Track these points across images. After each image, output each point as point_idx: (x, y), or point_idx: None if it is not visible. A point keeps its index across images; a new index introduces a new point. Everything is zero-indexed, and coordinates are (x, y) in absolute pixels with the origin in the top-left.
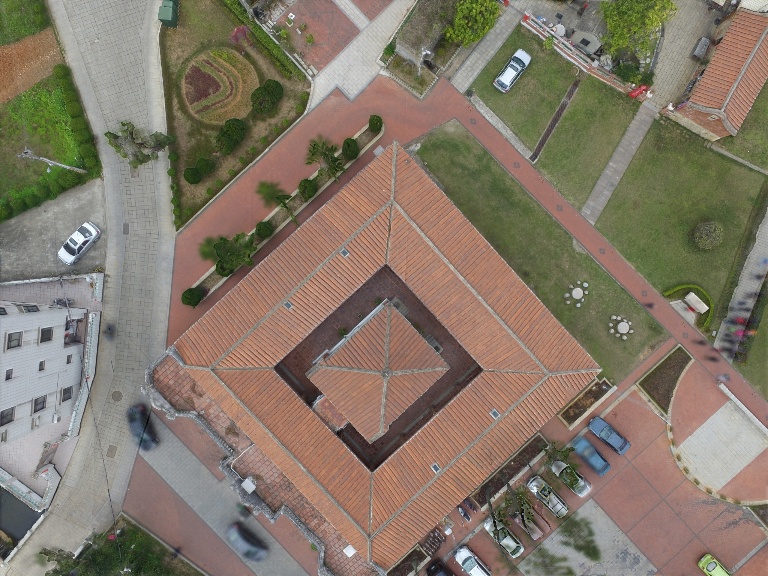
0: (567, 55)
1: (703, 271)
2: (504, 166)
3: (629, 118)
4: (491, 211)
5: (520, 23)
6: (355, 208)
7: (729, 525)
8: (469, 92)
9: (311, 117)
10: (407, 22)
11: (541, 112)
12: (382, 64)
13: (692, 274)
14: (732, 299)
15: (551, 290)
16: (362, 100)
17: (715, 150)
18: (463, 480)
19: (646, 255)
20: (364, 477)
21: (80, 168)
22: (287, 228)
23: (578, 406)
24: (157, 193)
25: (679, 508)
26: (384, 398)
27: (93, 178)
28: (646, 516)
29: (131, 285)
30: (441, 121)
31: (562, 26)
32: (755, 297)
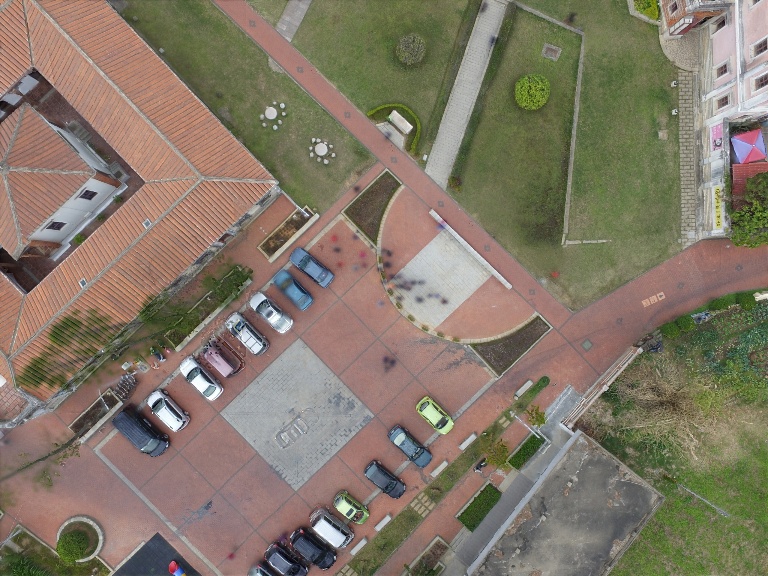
0: None
1: (410, 90)
2: None
3: None
4: (179, 28)
5: None
6: None
7: (450, 366)
8: None
9: None
10: None
11: None
12: None
13: (399, 94)
14: (443, 120)
15: (247, 113)
16: None
17: None
18: (121, 300)
19: (348, 73)
20: (14, 298)
21: None
22: None
23: (279, 237)
24: None
25: (395, 348)
26: (10, 199)
27: None
28: (359, 357)
29: None
30: None
31: None
32: (468, 118)
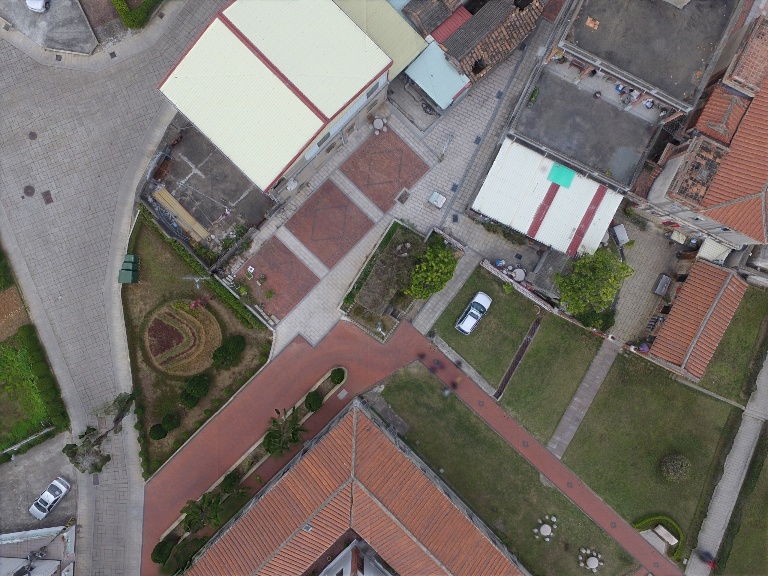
0: (528, 295)
1: (672, 500)
2: (468, 405)
3: (592, 353)
4: (457, 448)
5: (480, 264)
6: (317, 481)
7: None
8: (431, 333)
9: (274, 364)
10: (364, 284)
11: (504, 350)
12: (343, 312)
13: (661, 504)
14: (702, 527)
15: (519, 524)
16: (324, 346)
17: (680, 382)
18: None
19: (614, 487)
20: None
21: (48, 425)
22: (254, 474)
23: None
24: (125, 443)
25: None
26: None
27: (62, 431)
28: None
29: (103, 534)
30: (404, 363)
31: (521, 271)
32: (725, 524)
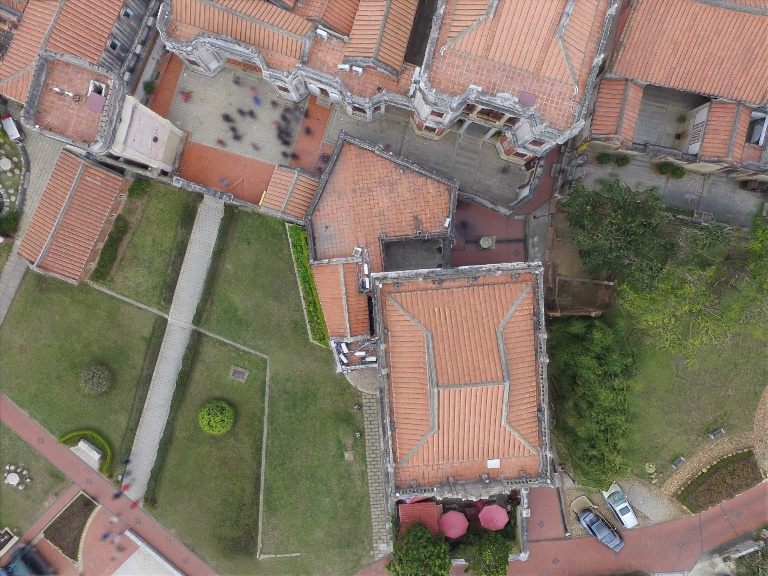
0: None
1: (101, 415)
2: None
3: (3, 259)
4: None
5: None
6: None
7: None
8: None
9: None
10: None
11: None
12: None
13: (90, 418)
14: (135, 442)
15: None
16: None
17: (99, 289)
18: None
19: (39, 401)
20: None
21: None
22: None
23: None
24: None
25: None
26: None
27: None
28: None
29: None
30: None
31: None
32: (159, 439)
